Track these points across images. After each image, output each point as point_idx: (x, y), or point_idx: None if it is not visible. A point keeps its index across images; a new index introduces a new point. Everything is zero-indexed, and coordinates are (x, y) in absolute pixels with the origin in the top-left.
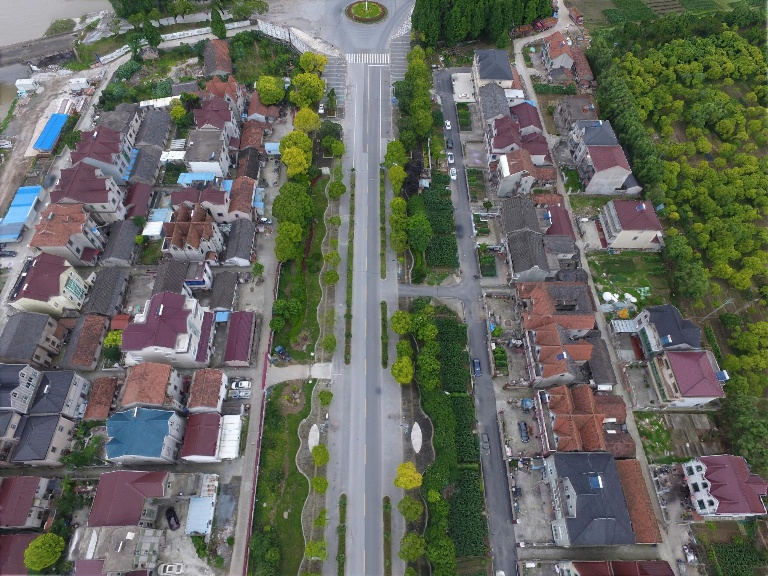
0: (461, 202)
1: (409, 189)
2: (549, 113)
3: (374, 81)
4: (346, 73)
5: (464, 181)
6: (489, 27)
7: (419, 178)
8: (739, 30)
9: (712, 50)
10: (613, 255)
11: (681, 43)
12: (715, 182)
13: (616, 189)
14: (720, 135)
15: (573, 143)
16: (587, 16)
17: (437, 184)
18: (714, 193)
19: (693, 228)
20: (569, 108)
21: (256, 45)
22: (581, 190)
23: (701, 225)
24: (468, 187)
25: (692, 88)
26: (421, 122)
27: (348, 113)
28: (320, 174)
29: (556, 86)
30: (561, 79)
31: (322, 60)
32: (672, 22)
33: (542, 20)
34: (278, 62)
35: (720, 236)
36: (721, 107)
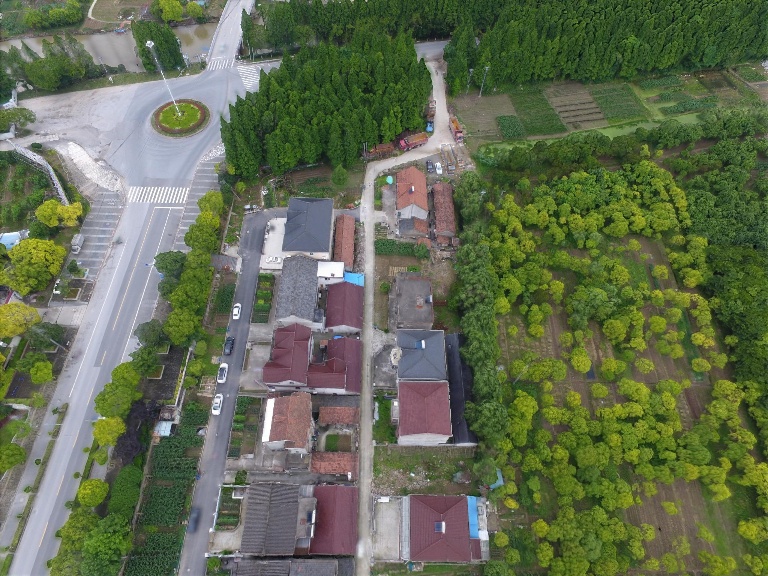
0: (214, 459)
1: (123, 454)
2: (384, 291)
3: (153, 235)
4: (119, 220)
5: (230, 417)
6: (327, 152)
7: (157, 420)
8: (666, 151)
9: (621, 192)
10: (412, 572)
11: (583, 178)
12: (581, 438)
13: (440, 443)
14: (608, 339)
15: (391, 362)
16: (474, 125)
17: (184, 428)
18: (577, 459)
19: (531, 535)
20: (399, 299)
21: (10, 171)
22: (392, 440)
23: (544, 528)
24: (230, 432)
25: (586, 251)
26: (171, 331)
27: (98, 292)
28: (11, 413)
29: (404, 244)
30: (412, 234)
31: (69, 213)
32: (574, 147)
33: (407, 137)
34: (25, 203)
35: (568, 554)
36: (614, 295)
